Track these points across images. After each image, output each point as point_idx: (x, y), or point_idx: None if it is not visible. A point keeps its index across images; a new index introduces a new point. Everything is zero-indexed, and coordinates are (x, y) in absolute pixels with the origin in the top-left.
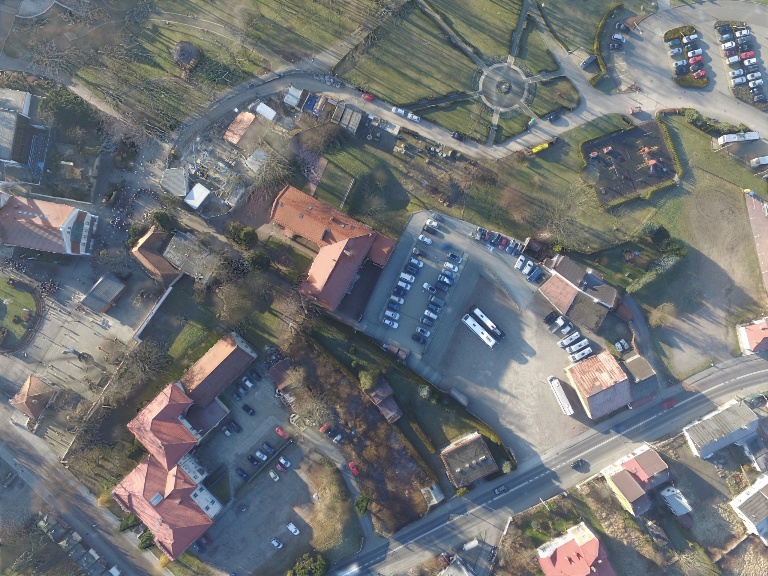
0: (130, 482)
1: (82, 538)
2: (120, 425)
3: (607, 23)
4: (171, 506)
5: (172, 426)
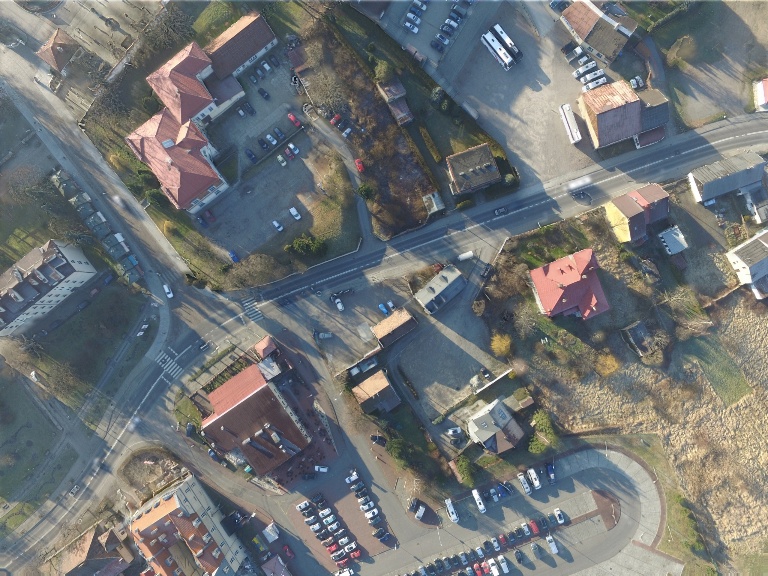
0: (144, 129)
1: (91, 200)
2: (139, 82)
3: None
4: (181, 153)
5: (190, 80)
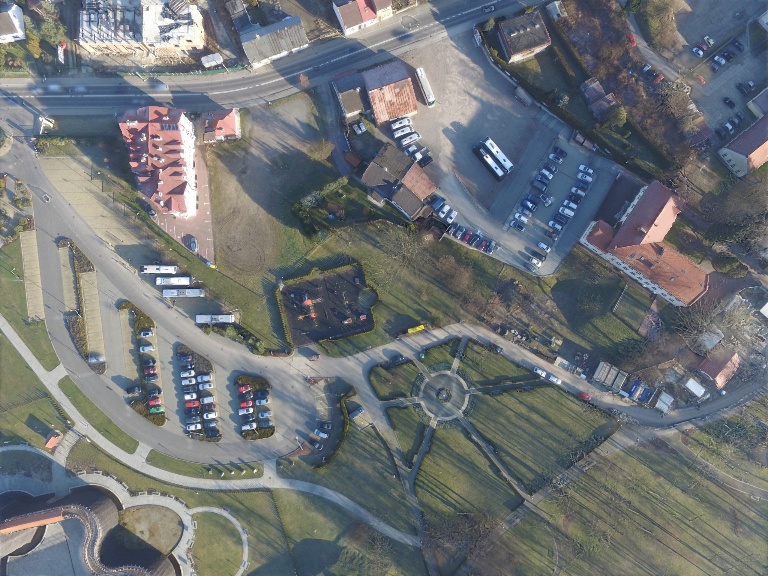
0: None
1: None
2: None
3: (331, 452)
4: None
5: None
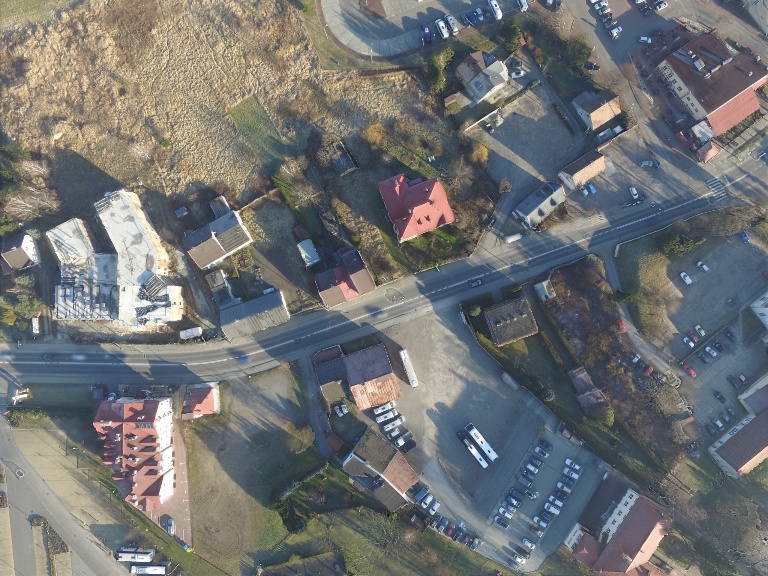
0: None
1: None
2: None
3: None
4: None
5: None
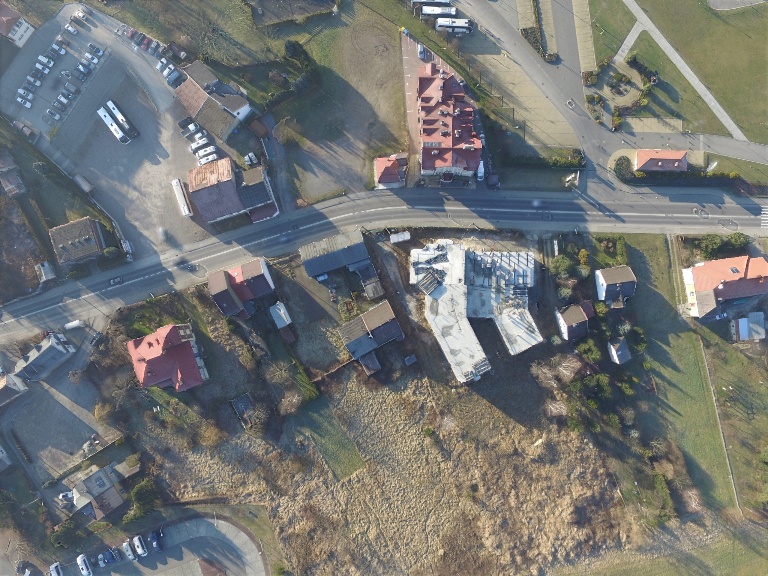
0: None
1: None
2: None
3: None
4: None
5: None
